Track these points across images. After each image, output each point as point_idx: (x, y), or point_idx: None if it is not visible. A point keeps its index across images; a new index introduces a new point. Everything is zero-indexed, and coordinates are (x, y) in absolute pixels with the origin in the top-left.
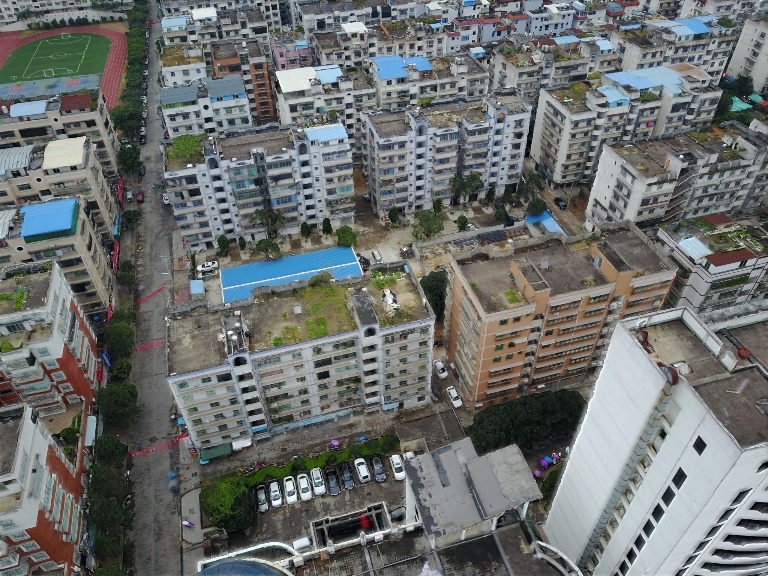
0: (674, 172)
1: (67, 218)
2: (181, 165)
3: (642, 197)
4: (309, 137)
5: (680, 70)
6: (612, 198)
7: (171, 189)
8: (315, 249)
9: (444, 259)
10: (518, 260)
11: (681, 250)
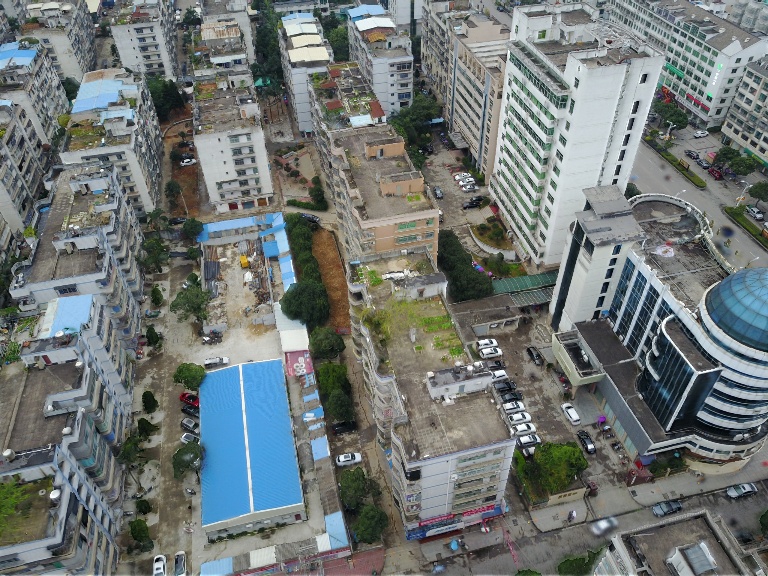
0: (255, 114)
1: None
2: (31, 519)
3: (264, 142)
4: (70, 332)
5: (101, 77)
6: (236, 167)
7: (71, 547)
8: (169, 430)
9: (233, 309)
10: (382, 182)
11: (359, 127)
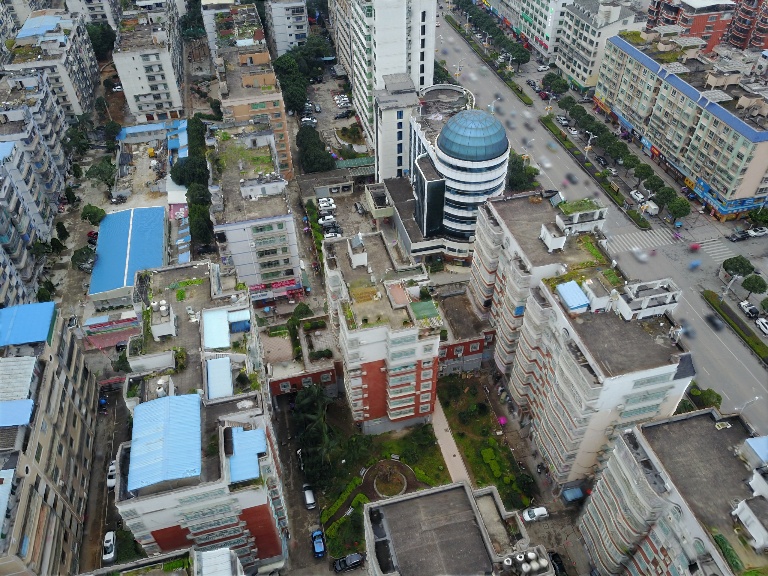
0: (165, 40)
1: (34, 306)
2: None
3: (171, 62)
4: None
5: (43, 14)
6: (149, 82)
7: None
8: None
9: (138, 183)
10: (243, 76)
11: None
